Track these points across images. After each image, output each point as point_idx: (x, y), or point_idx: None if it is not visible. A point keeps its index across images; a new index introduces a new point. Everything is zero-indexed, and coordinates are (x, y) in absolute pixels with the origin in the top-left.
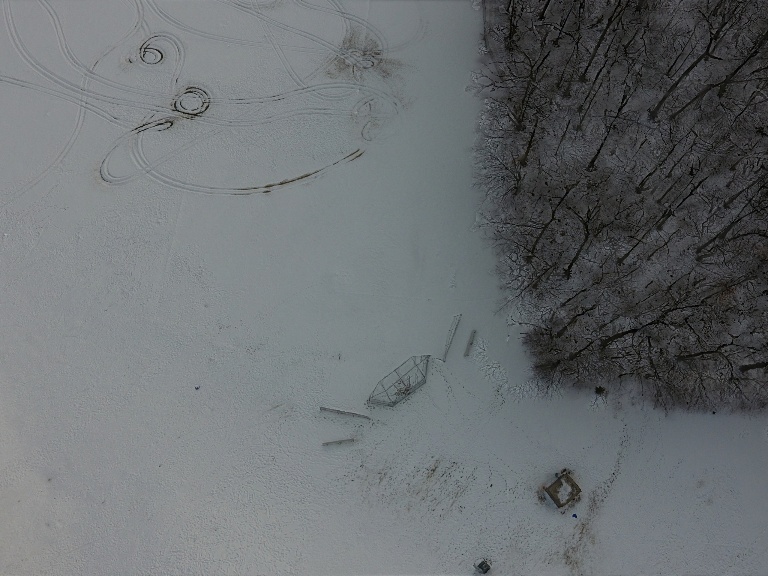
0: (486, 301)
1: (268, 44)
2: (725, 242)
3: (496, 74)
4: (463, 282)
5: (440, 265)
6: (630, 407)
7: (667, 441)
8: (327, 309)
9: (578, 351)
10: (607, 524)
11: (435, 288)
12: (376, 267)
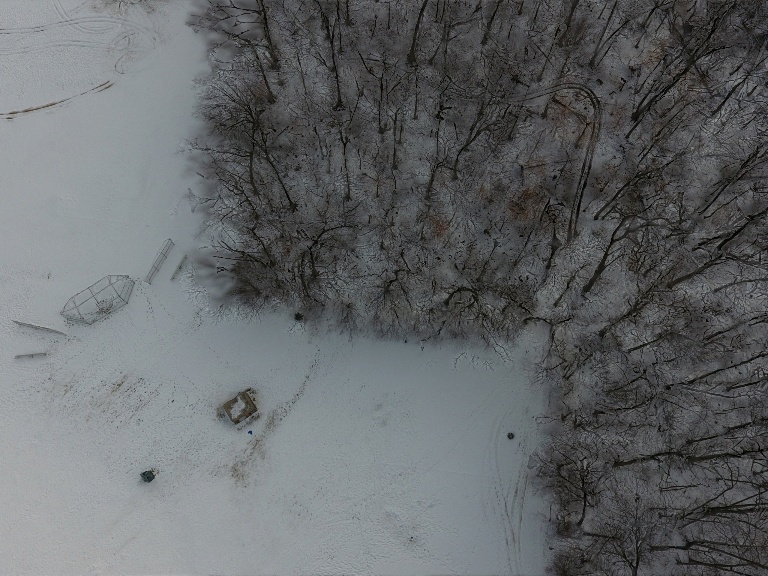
0: (195, 227)
1: None
2: (456, 182)
3: None
4: (183, 210)
5: (165, 193)
6: None
7: (355, 366)
8: (46, 231)
9: None
10: (280, 441)
11: (156, 215)
12: (102, 193)
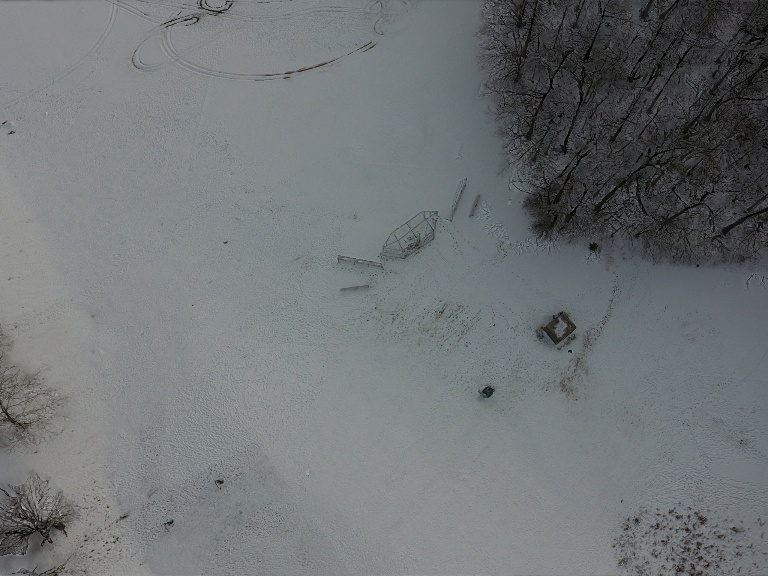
0: (489, 167)
1: None
2: (710, 124)
3: None
4: (468, 154)
5: (447, 140)
6: (621, 261)
7: (655, 290)
8: (343, 177)
9: (574, 210)
10: (600, 358)
11: (442, 159)
12: (388, 141)
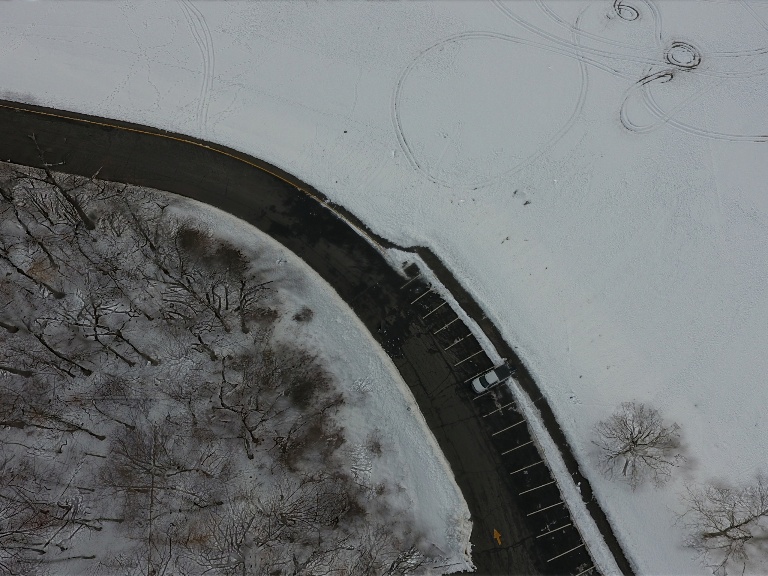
0: None
1: (734, 1)
2: None
3: None
4: None
5: None
6: None
7: None
8: None
9: None
10: None
11: None
12: None
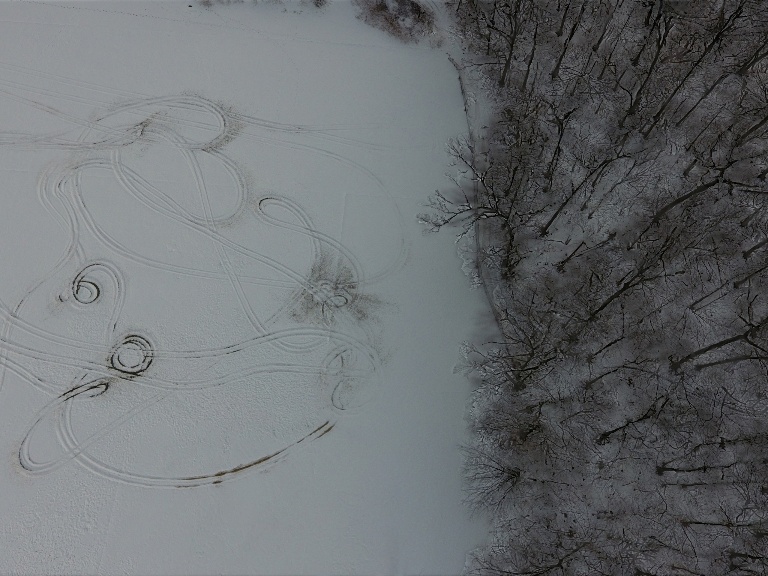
0: None
1: (224, 274)
2: (764, 543)
3: (491, 314)
4: None
5: None
6: None
7: None
8: None
9: None
10: None
11: None
12: None
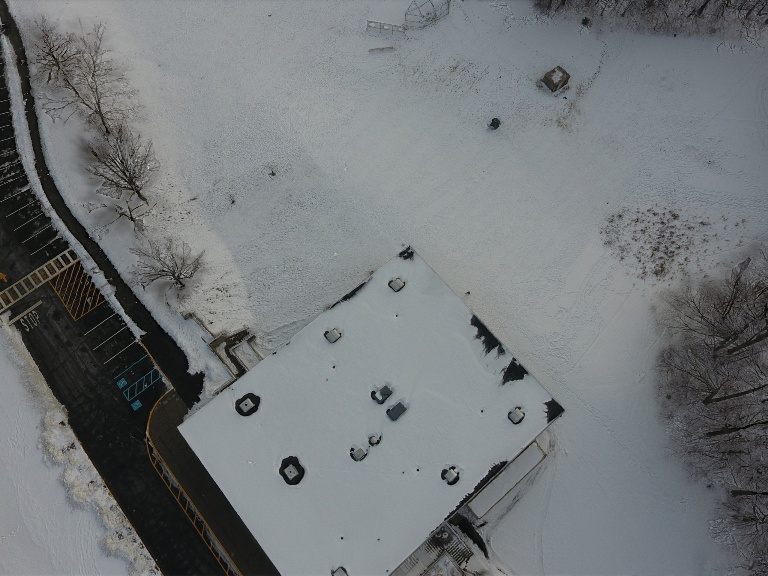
0: None
1: None
2: None
3: None
4: None
5: None
6: (609, 33)
7: (638, 54)
8: None
9: None
10: (590, 103)
11: None
12: None
